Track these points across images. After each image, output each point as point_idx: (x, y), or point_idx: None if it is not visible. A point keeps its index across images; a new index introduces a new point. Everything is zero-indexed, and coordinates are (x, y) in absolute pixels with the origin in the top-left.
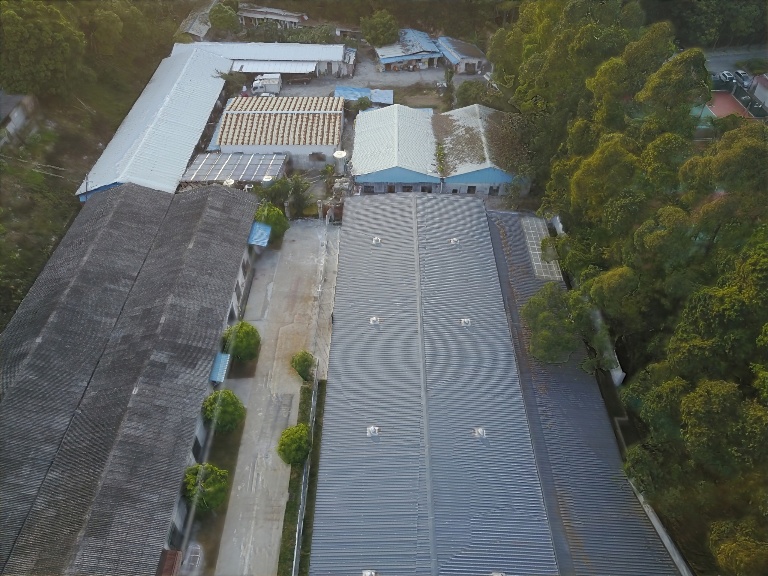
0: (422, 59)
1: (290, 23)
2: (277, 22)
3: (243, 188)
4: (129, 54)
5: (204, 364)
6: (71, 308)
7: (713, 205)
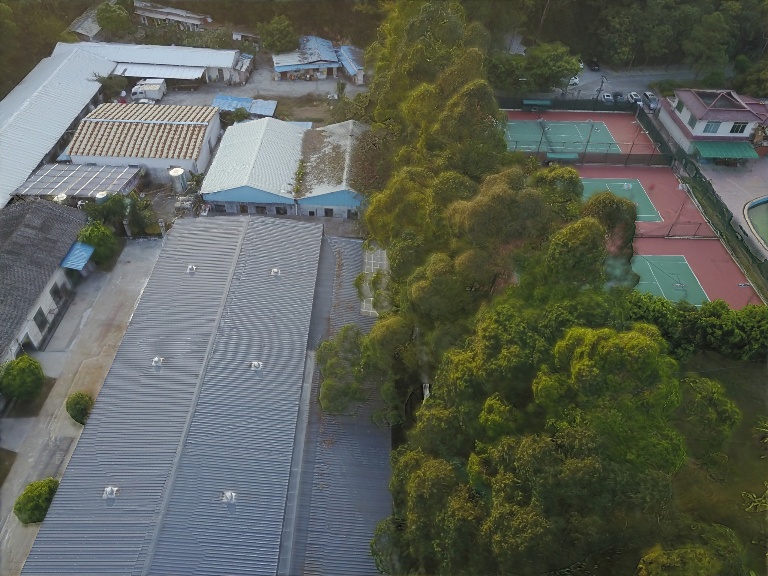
0: (320, 68)
1: (192, 25)
2: (179, 23)
3: (77, 204)
4: (6, 52)
5: None
6: None
7: (464, 258)
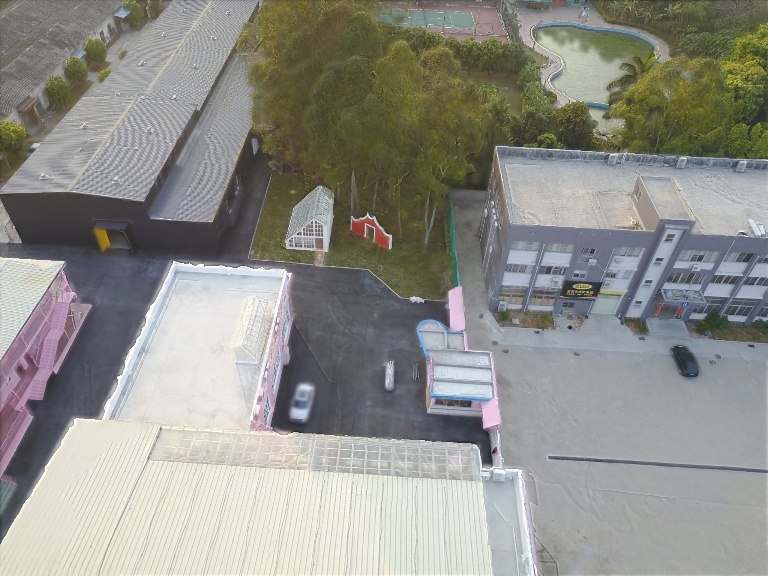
0: None
1: None
2: None
3: None
4: None
5: (69, 49)
6: (1, 25)
7: None
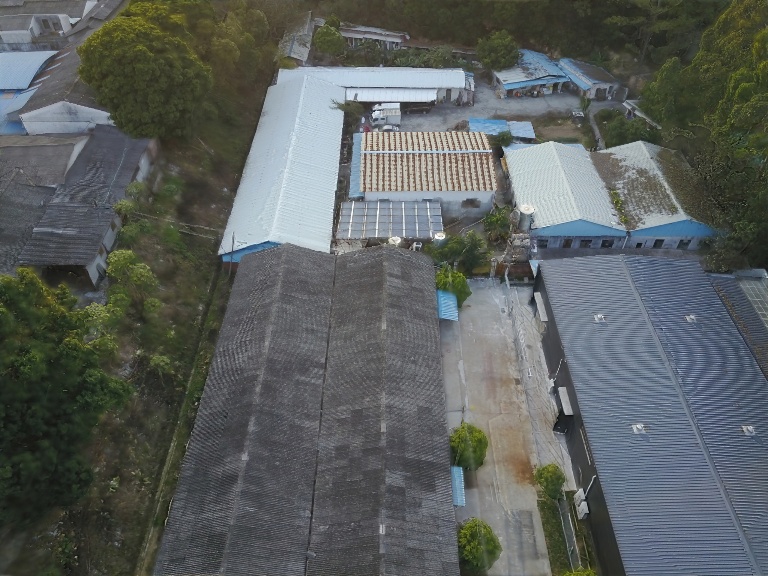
0: (547, 84)
1: (391, 43)
2: (376, 42)
3: (410, 246)
4: (232, 82)
5: (443, 485)
6: (268, 411)
7: None
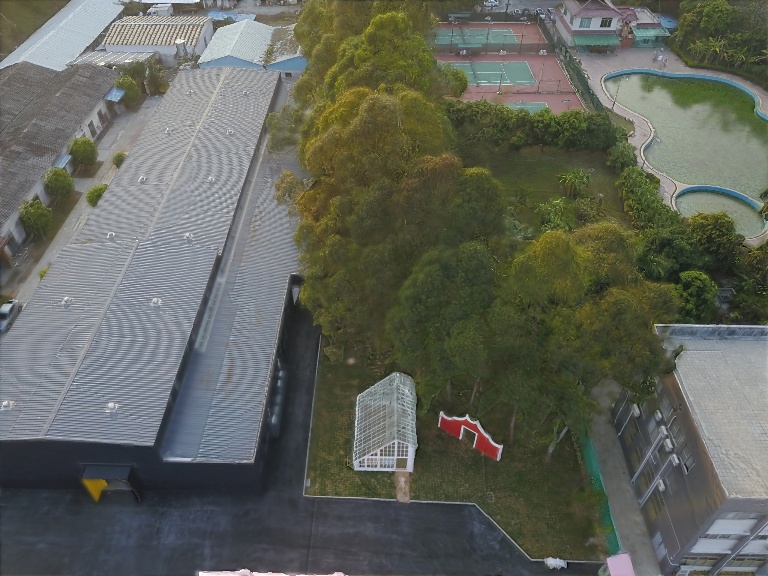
0: None
1: None
2: None
3: None
4: None
5: (49, 156)
6: None
7: (335, 23)
